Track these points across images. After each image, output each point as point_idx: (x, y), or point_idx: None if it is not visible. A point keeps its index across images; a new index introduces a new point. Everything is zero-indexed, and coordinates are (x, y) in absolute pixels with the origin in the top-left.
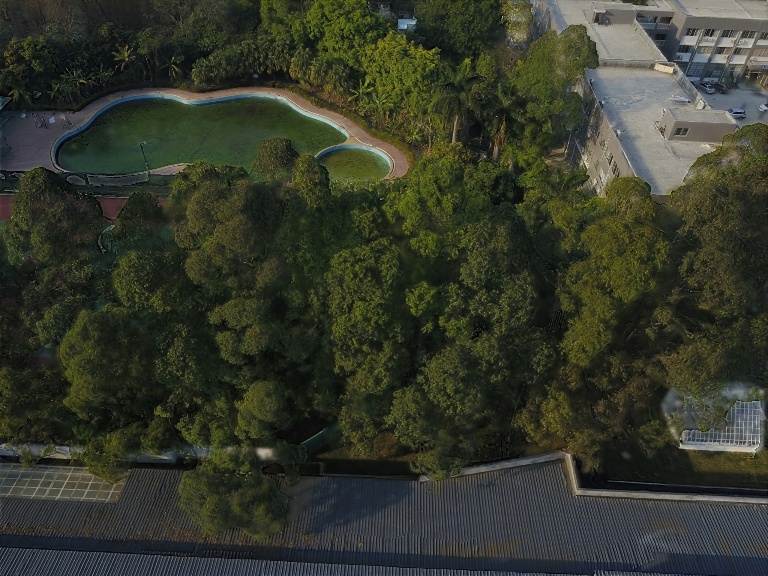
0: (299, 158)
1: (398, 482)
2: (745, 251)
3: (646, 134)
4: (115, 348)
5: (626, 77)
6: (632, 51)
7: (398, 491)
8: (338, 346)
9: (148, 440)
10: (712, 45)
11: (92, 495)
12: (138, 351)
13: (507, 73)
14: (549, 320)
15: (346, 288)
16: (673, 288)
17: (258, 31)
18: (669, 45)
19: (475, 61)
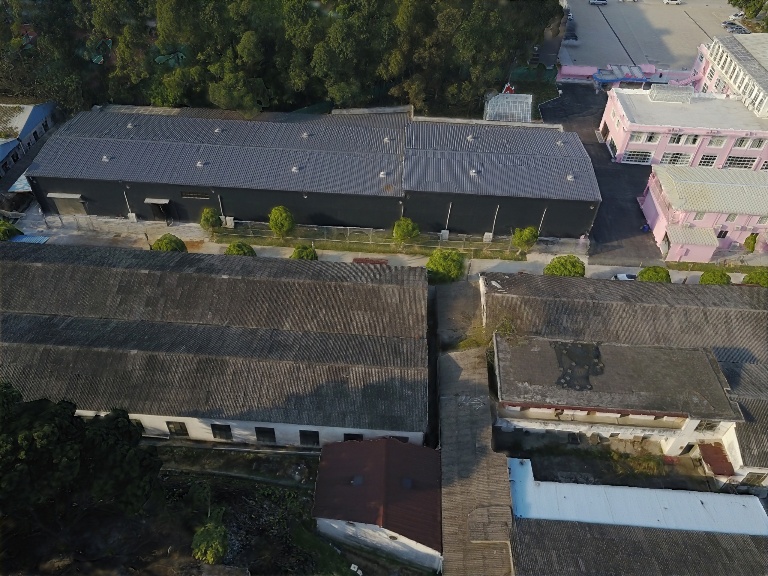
0: None
1: (321, 115)
2: None
3: None
4: (182, 2)
5: None
6: None
7: (320, 117)
8: (286, 19)
9: (194, 69)
10: None
11: (163, 114)
12: (192, 5)
13: None
14: None
15: None
16: None
17: None
18: None
19: None
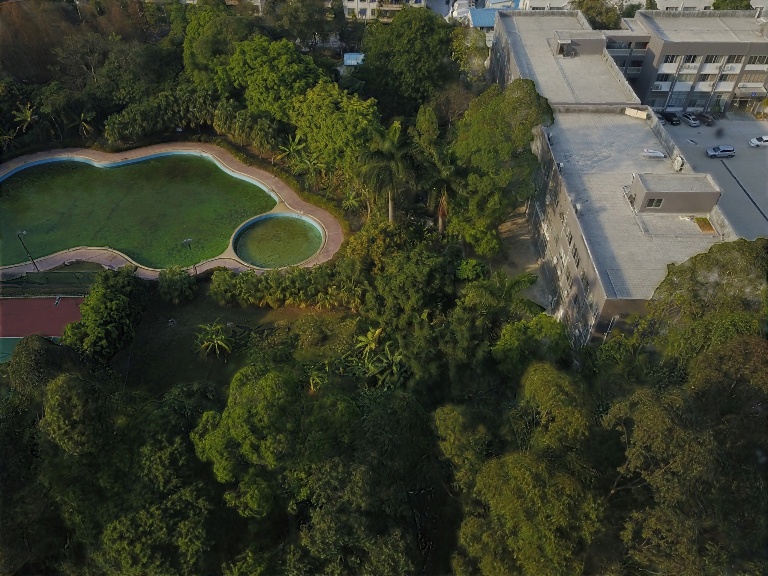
0: (47, 385)
1: None
2: (723, 476)
3: (613, 205)
4: None
5: (592, 126)
6: (601, 89)
7: None
8: None
9: None
10: (694, 72)
11: None
12: None
13: (456, 122)
14: (449, 568)
15: (128, 572)
16: (614, 563)
17: (179, 79)
18: (646, 73)
19: (424, 104)
